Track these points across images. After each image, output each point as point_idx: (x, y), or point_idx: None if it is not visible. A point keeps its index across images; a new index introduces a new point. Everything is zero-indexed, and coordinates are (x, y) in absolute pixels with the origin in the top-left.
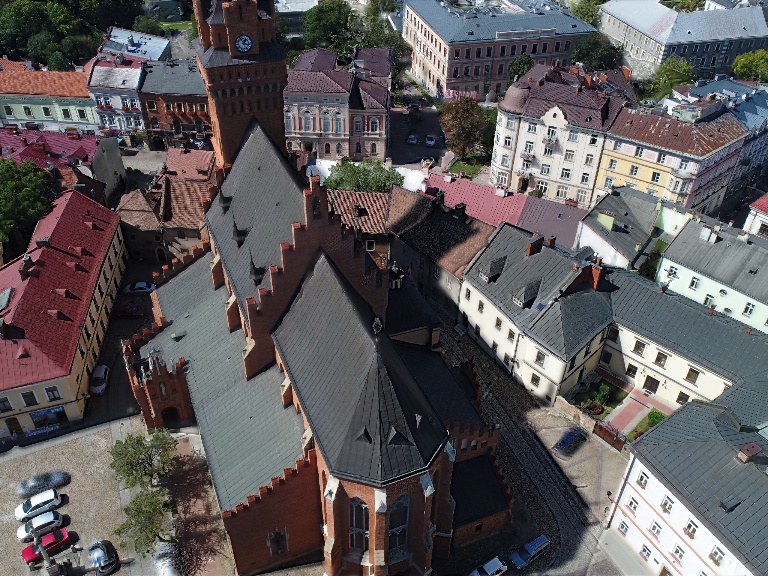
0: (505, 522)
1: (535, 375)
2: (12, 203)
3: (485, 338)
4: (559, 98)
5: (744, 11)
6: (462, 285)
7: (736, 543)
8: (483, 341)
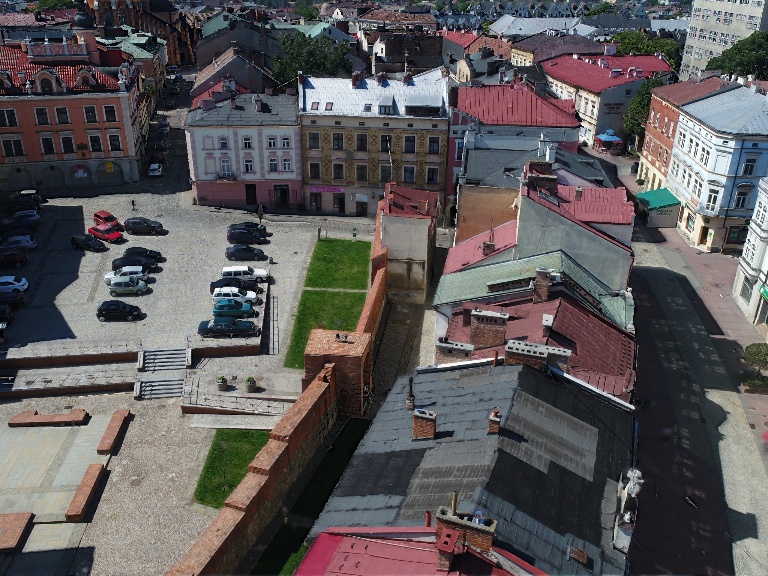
0: (167, 64)
1: None
2: (55, 4)
3: None
4: None
5: (565, 20)
6: None
7: None
8: None
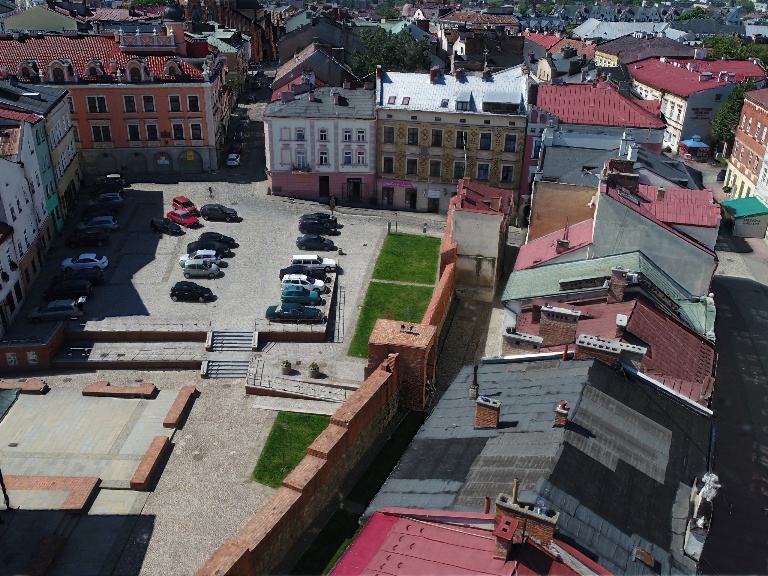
0: (250, 60)
1: None
2: (148, 2)
3: None
4: None
5: None
6: None
7: None
8: None
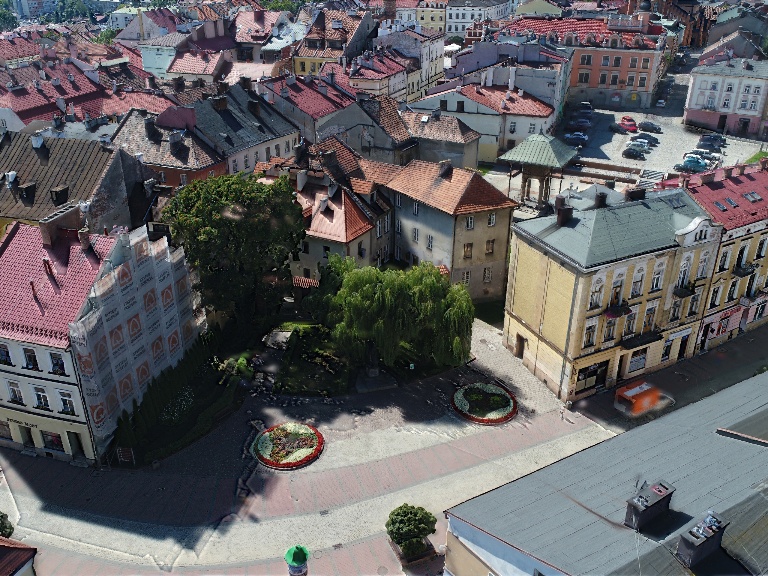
0: (679, 45)
1: None
2: None
3: None
4: None
5: None
6: None
7: None
8: None
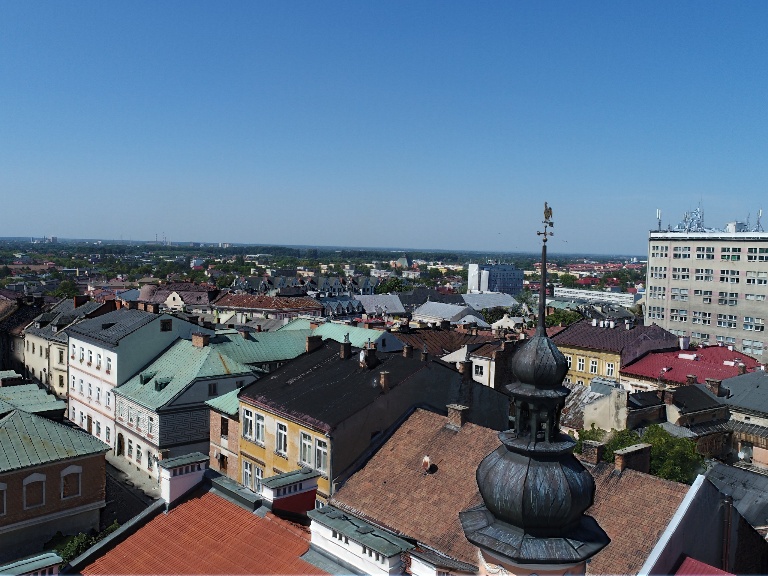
0: None
1: (61, 377)
2: None
3: (37, 375)
4: (179, 288)
5: (384, 297)
6: (25, 341)
7: (101, 337)
8: (36, 379)
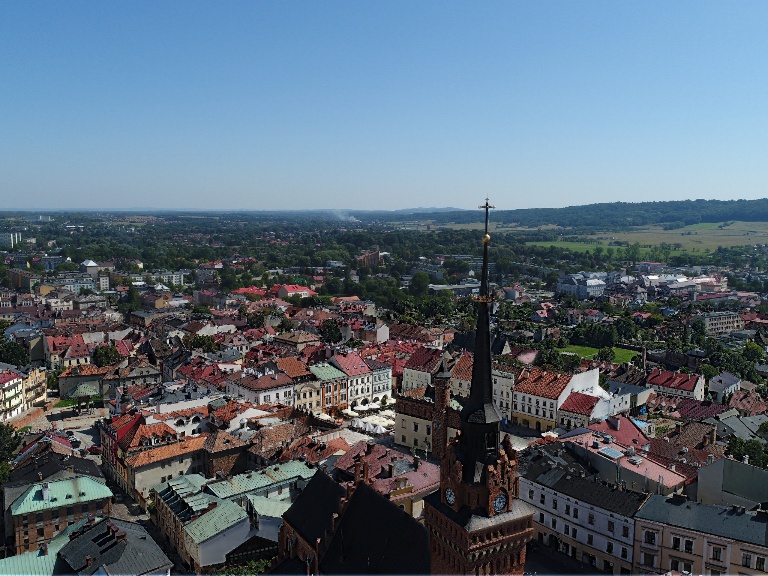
0: None
1: None
2: None
3: None
4: None
5: None
6: None
7: None
8: None
